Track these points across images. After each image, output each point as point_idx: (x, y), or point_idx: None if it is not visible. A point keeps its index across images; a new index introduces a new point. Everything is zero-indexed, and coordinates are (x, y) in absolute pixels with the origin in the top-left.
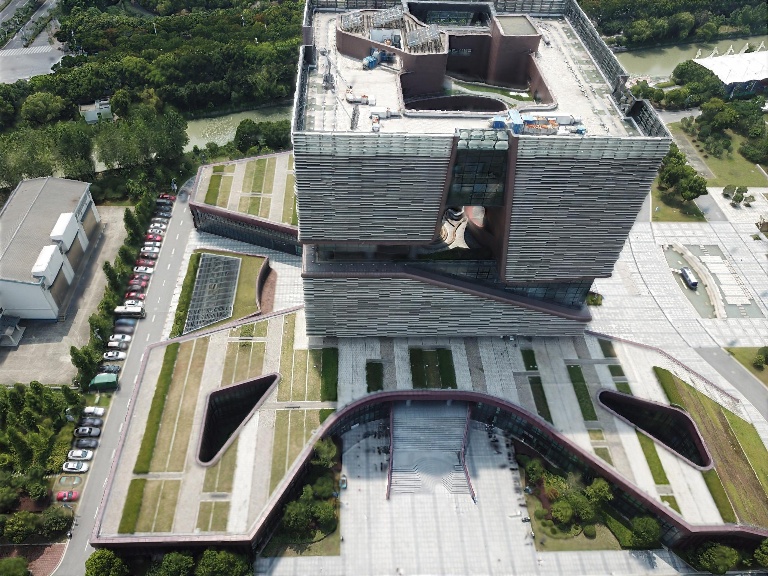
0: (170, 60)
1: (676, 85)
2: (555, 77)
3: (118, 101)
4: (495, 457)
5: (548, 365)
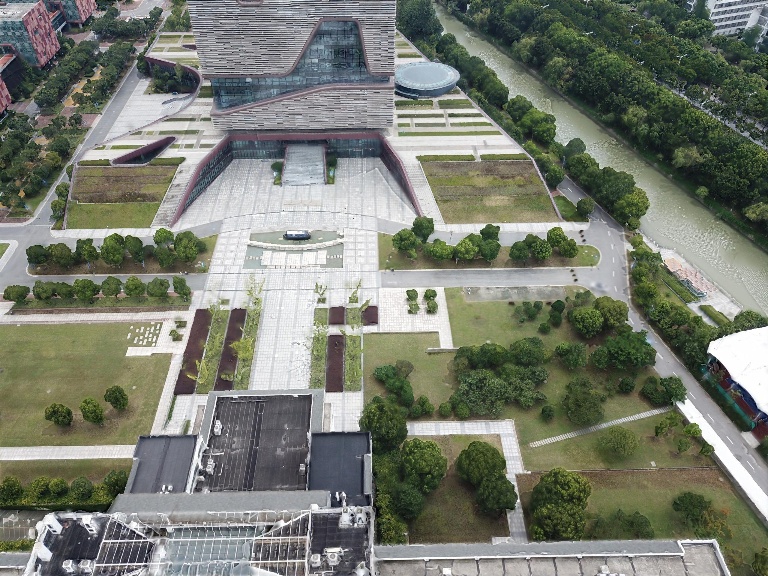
0: (522, 4)
1: None
2: None
3: None
4: None
5: (202, 125)
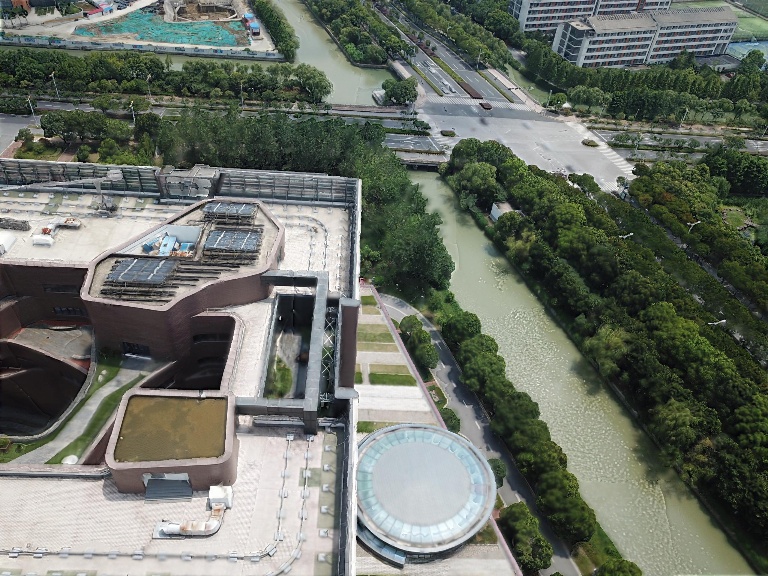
0: (592, 237)
1: None
2: (5, 503)
3: (503, 217)
4: None
5: None
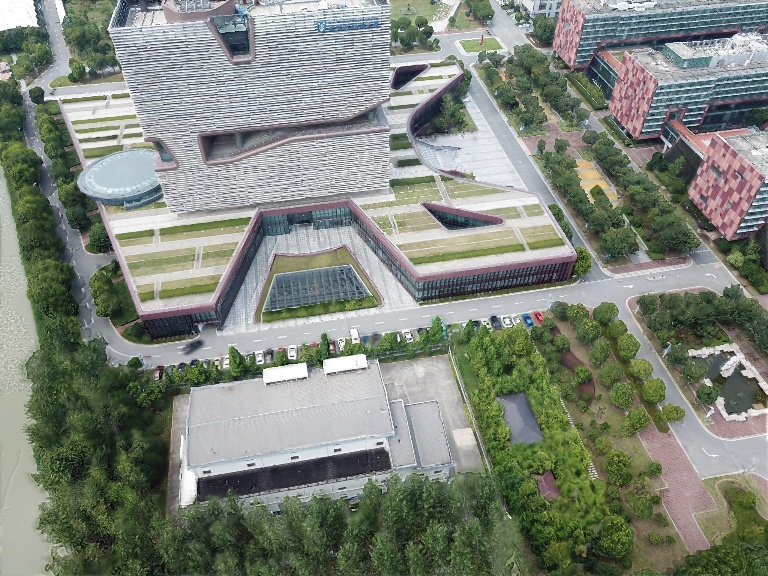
0: None
1: (11, 55)
2: None
3: None
4: (430, 143)
5: None
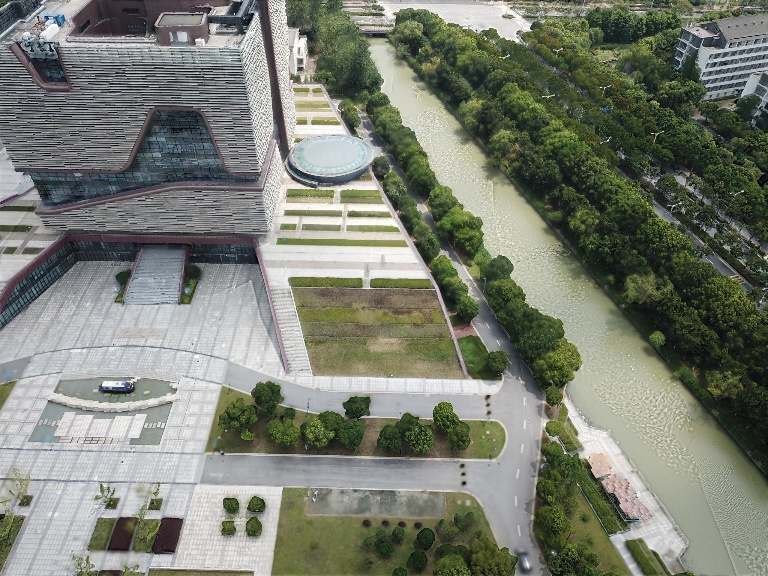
0: (476, 55)
1: None
2: None
3: None
4: None
5: None
